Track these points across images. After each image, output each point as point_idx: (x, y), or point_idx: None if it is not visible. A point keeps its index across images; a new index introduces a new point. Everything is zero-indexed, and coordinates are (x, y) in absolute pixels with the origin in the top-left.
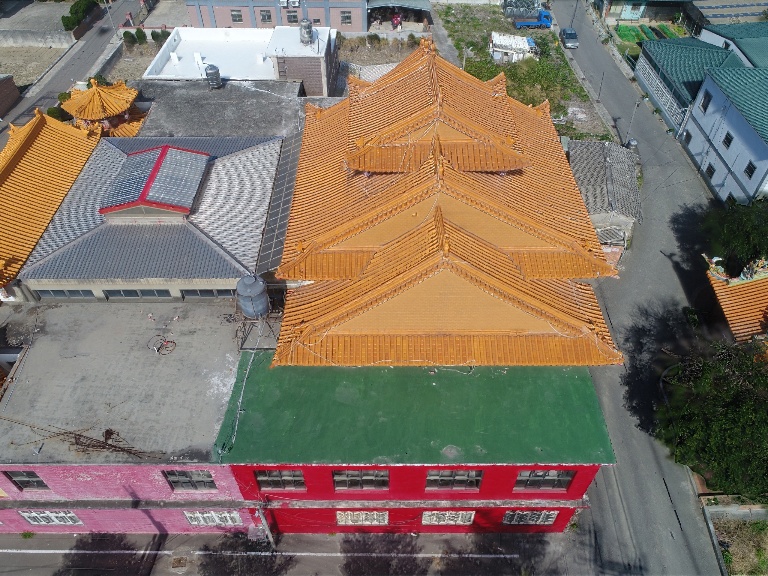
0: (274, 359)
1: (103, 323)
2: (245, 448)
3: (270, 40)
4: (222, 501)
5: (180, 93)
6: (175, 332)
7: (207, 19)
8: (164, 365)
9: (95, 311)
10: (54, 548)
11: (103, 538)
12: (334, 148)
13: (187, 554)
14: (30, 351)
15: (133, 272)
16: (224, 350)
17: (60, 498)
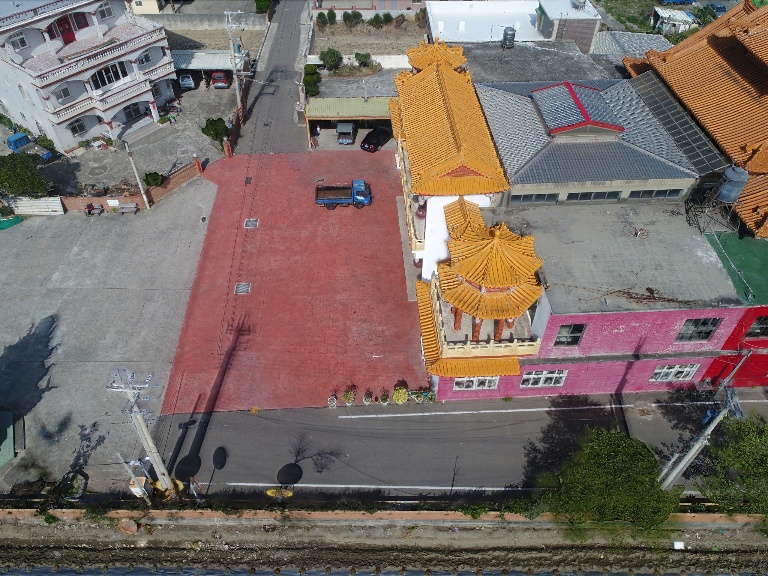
0: (758, 232)
1: (574, 219)
2: (764, 295)
3: (543, 6)
4: (703, 352)
5: (479, 53)
6: (639, 223)
7: (388, 1)
8: (651, 245)
9: (560, 211)
10: (535, 407)
11: (570, 399)
12: (711, 80)
13: (646, 406)
14: (534, 240)
15: (601, 176)
16: (689, 234)
17: (576, 354)
